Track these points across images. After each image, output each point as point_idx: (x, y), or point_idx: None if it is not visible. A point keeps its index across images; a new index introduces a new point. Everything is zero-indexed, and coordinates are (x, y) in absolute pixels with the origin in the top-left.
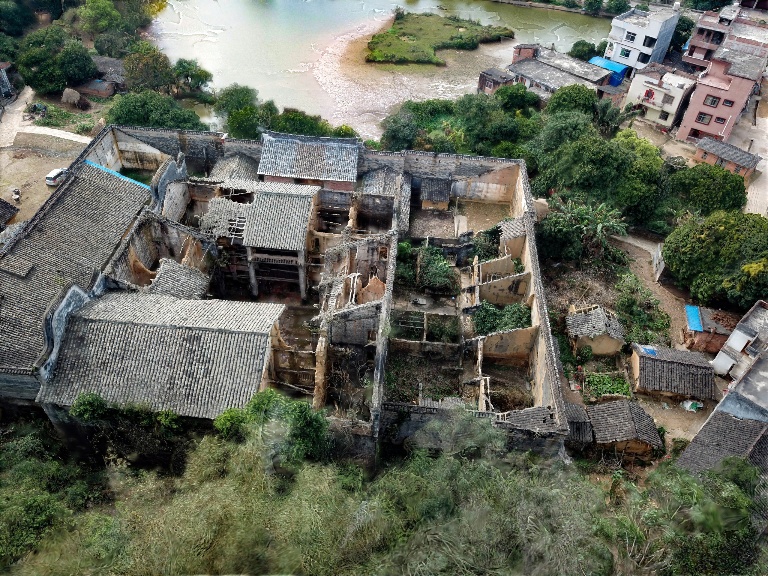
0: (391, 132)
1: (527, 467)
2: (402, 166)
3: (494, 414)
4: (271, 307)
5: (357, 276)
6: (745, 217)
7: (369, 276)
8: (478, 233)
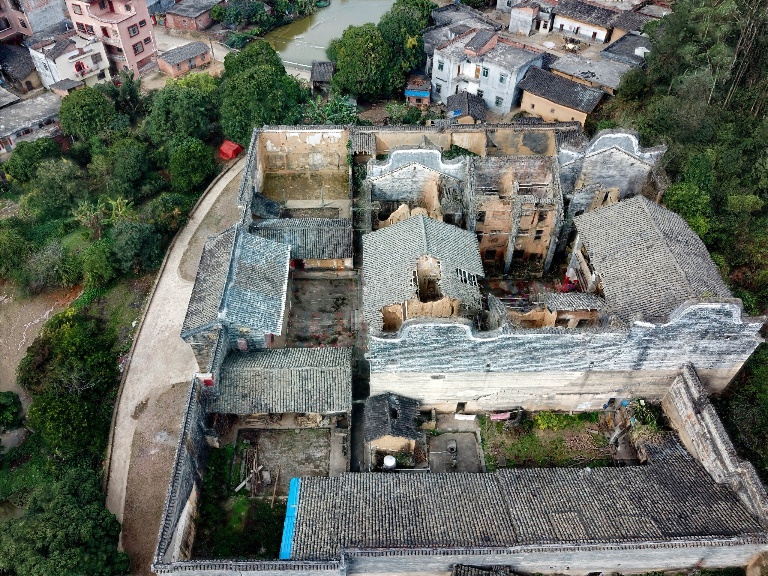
0: (139, 242)
1: None
2: None
3: (585, 145)
4: (584, 222)
5: (518, 183)
6: (365, 30)
7: None
8: (352, 172)
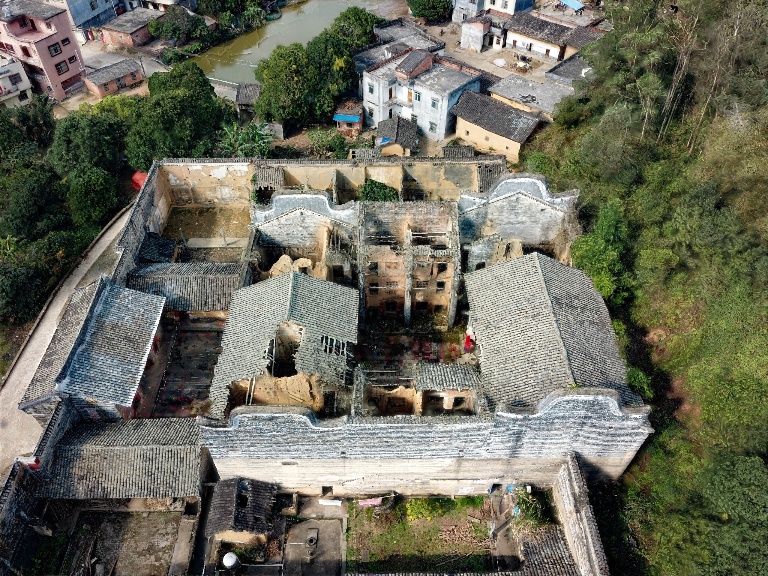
0: (11, 289)
1: (555, 160)
2: (132, 260)
3: None
4: (474, 280)
5: (412, 232)
6: (289, 52)
7: (386, 242)
8: None
